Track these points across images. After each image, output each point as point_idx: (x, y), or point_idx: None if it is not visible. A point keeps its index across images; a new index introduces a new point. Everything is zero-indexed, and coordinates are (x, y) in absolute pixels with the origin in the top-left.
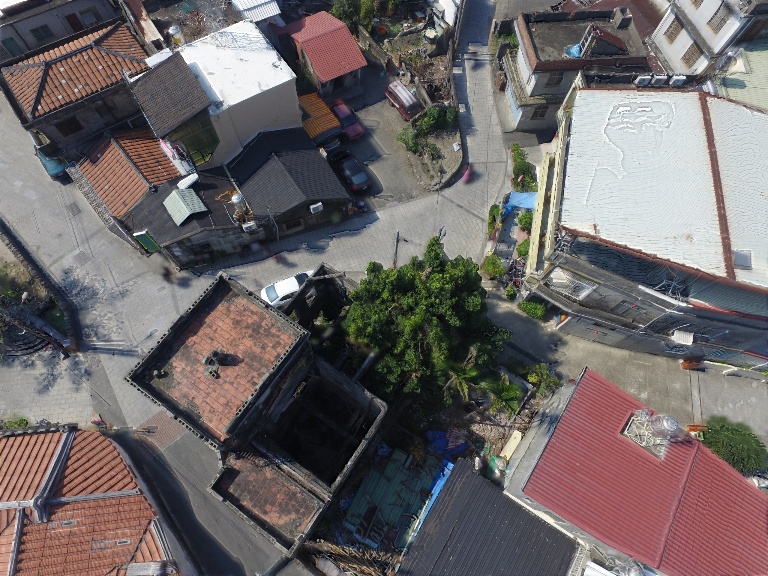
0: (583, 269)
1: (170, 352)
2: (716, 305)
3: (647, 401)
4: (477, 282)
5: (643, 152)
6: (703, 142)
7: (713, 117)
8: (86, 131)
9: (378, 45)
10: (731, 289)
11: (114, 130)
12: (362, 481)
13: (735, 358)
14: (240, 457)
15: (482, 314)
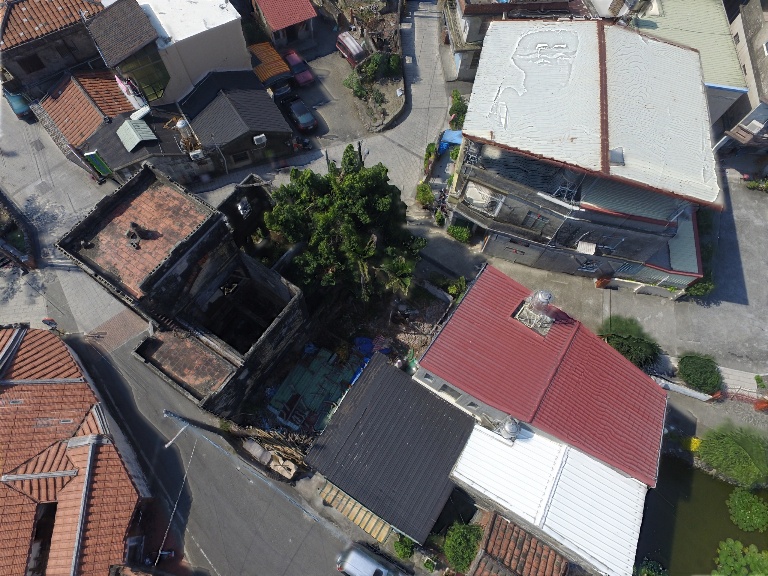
0: (490, 180)
1: (98, 228)
2: (602, 206)
3: None
4: (394, 193)
5: (557, 84)
6: (596, 62)
7: (607, 41)
8: (48, 70)
9: (333, 3)
10: (610, 186)
11: (75, 71)
12: (288, 374)
13: (640, 273)
14: (164, 330)
15: (400, 223)
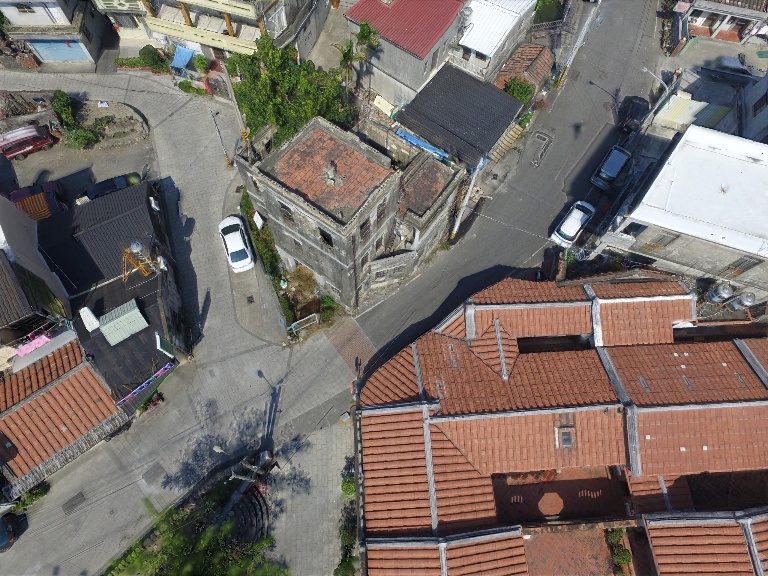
0: None
1: None
2: None
3: None
4: None
5: None
6: None
7: None
8: None
9: None
10: None
11: None
12: None
13: None
14: None
15: None
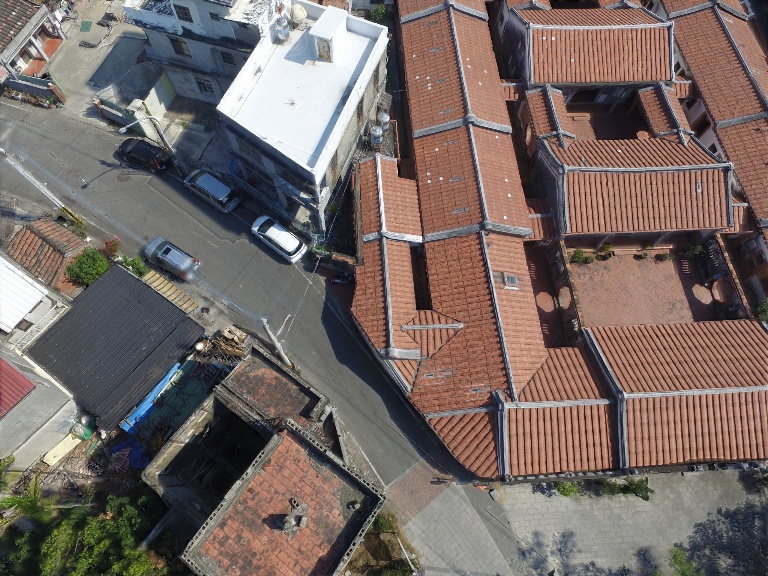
0: None
1: (348, 535)
2: None
3: None
4: None
5: None
6: None
7: None
8: None
9: None
10: None
11: None
12: None
13: None
14: None
15: None
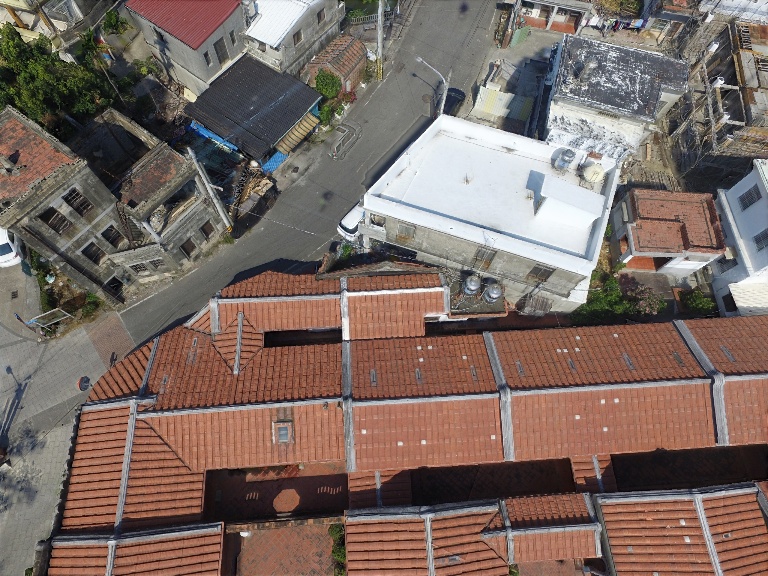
0: None
1: None
2: None
3: None
4: None
5: None
6: None
7: None
8: None
9: None
10: None
11: None
12: None
13: None
14: (120, 200)
15: None
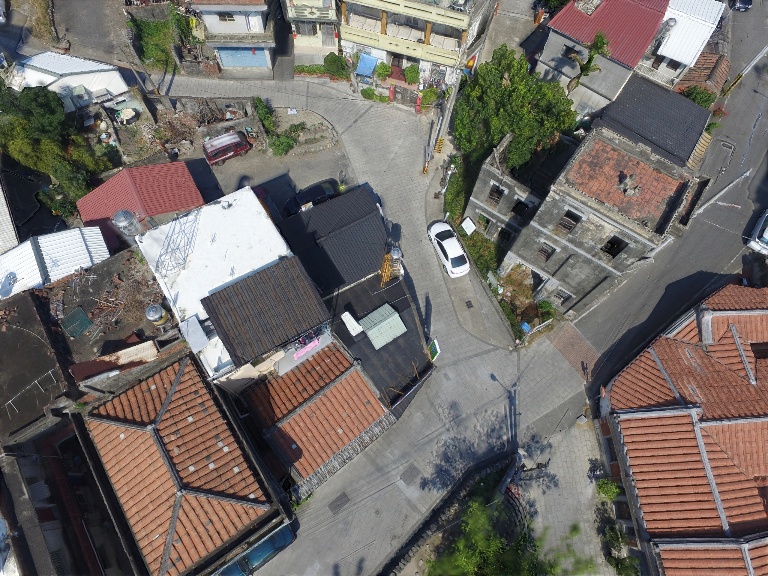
0: None
1: None
2: None
3: (521, 39)
4: None
5: None
6: None
7: None
8: None
9: None
10: None
11: (251, 436)
12: None
13: None
14: None
15: None
